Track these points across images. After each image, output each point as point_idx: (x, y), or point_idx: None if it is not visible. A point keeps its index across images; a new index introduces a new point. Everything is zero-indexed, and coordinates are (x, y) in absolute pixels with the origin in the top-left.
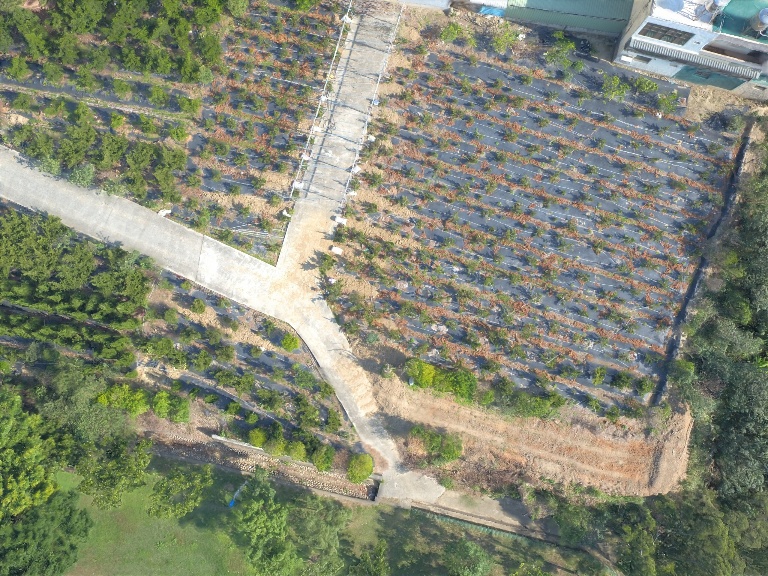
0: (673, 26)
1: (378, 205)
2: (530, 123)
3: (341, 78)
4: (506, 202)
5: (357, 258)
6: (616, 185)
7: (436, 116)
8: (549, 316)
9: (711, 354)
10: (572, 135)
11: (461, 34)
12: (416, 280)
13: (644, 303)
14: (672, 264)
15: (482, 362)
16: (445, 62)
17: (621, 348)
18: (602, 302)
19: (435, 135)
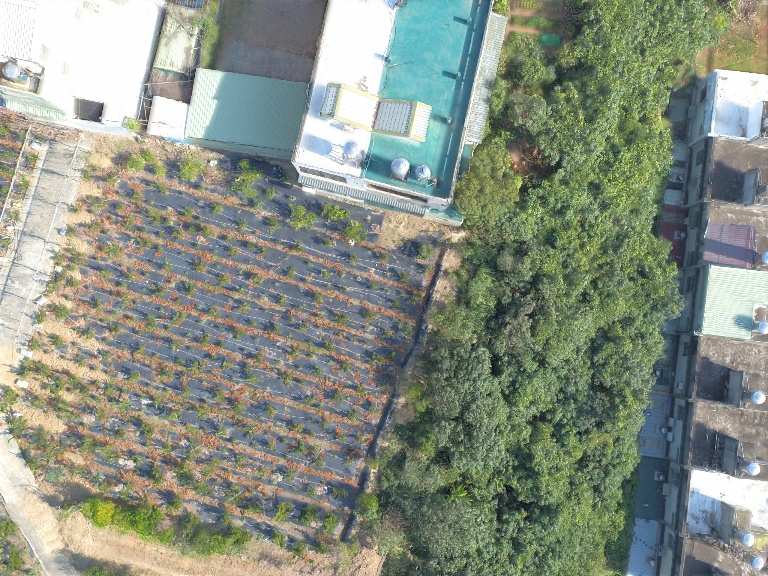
0: (320, 170)
1: (65, 337)
2: (220, 251)
3: (29, 207)
4: (195, 333)
5: (43, 391)
6: (308, 314)
7: (125, 245)
8: (239, 449)
9: (398, 488)
10: (262, 264)
11: (152, 160)
12: (101, 414)
13: (334, 435)
14: (364, 395)
15: (170, 497)
16: (135, 189)
17: (311, 481)
18: (293, 434)
19: (124, 264)
